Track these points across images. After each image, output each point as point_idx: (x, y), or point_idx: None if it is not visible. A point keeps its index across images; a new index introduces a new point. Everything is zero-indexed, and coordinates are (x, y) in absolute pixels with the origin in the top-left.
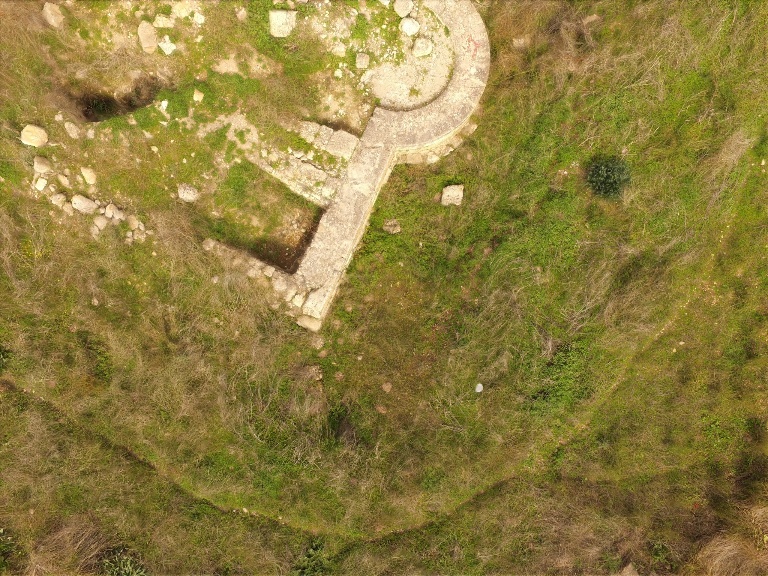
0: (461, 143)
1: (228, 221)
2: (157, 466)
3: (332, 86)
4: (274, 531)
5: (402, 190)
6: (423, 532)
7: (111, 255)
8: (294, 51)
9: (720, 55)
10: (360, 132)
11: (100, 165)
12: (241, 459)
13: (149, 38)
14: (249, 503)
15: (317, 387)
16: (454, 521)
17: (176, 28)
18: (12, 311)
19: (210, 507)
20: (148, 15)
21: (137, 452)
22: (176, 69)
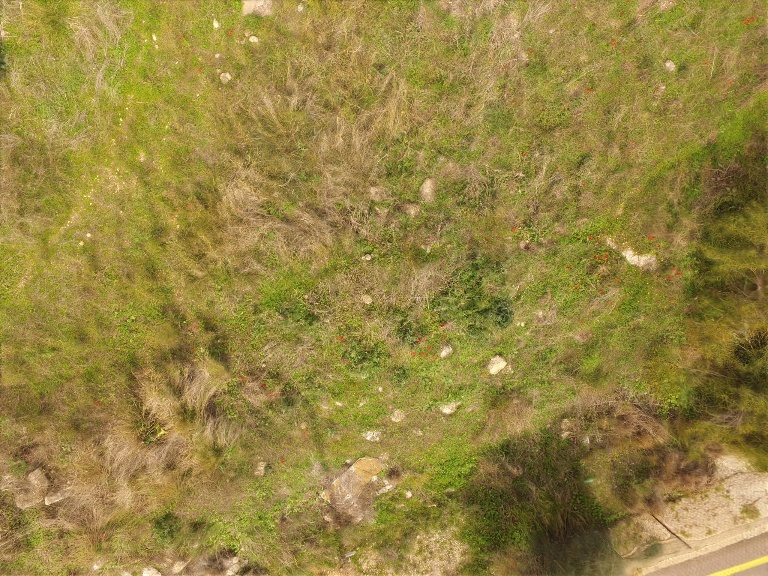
0: None
1: None
2: None
3: None
4: None
5: None
6: None
7: None
8: None
9: None
10: None
11: None
12: None
13: None
14: None
15: None
16: None
17: None
18: None
19: None
20: None
21: None
22: None
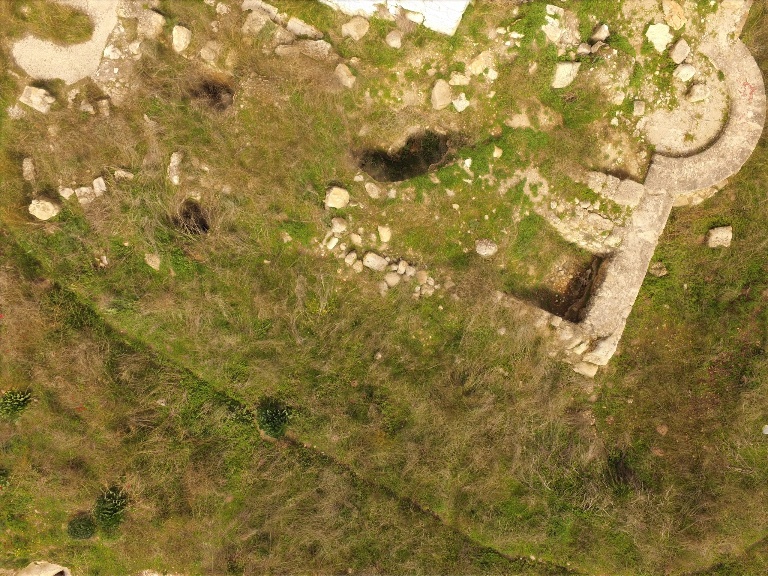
0: (726, 184)
1: (510, 272)
2: (441, 516)
3: (610, 134)
4: None
5: (669, 233)
6: (713, 574)
7: (407, 312)
8: (573, 101)
9: None
10: (640, 179)
11: (399, 224)
12: (530, 508)
13: (445, 96)
14: (538, 551)
15: (592, 432)
16: (745, 562)
17: (471, 85)
18: (293, 368)
19: (497, 556)
20: (441, 73)
21: (421, 503)
22: (465, 125)
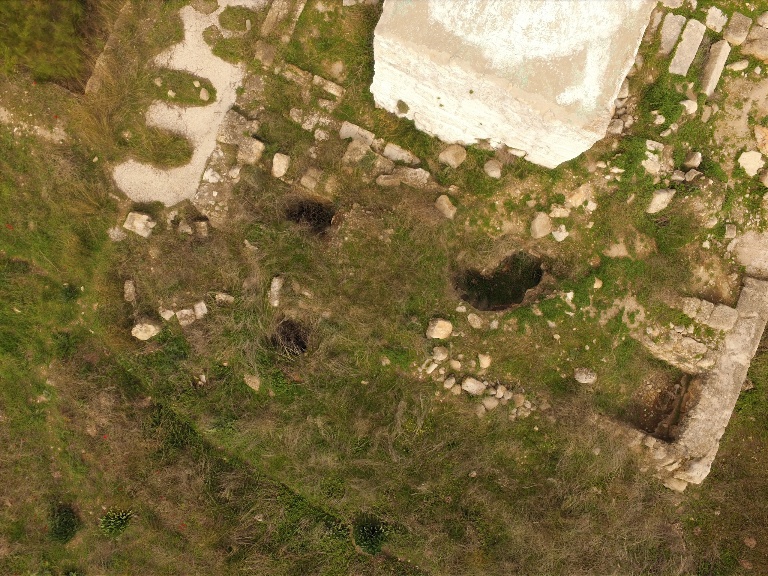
0: None
1: (604, 392)
2: None
3: (702, 257)
4: None
5: None
6: None
7: (506, 437)
8: (666, 226)
9: None
10: (732, 302)
11: (499, 352)
12: None
13: (545, 228)
14: None
15: (681, 544)
16: None
17: (571, 217)
18: (389, 485)
19: None
20: (541, 204)
21: None
22: (563, 253)
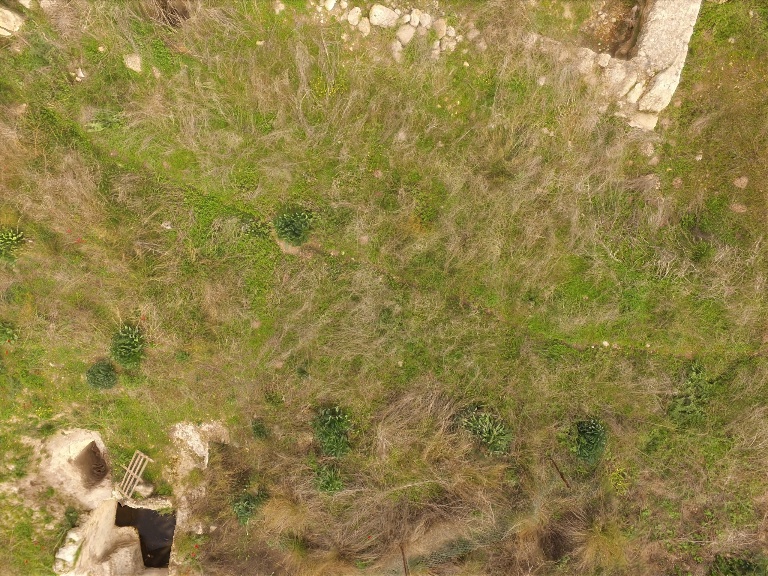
0: None
1: (543, 12)
2: (495, 312)
3: None
4: (646, 360)
5: None
6: None
7: None
8: None
9: None
10: None
11: None
12: (597, 285)
13: None
14: (612, 334)
15: (658, 197)
16: None
17: None
18: (307, 165)
19: (565, 347)
20: None
21: (471, 300)
22: None
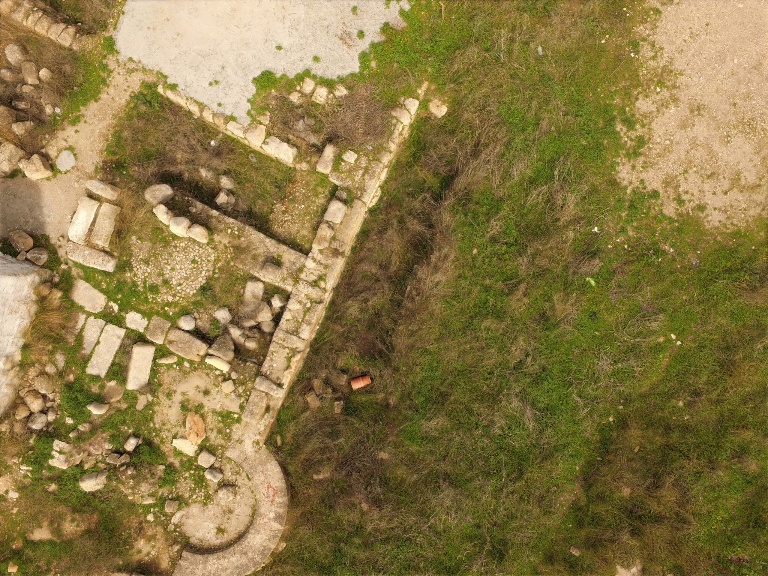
0: (271, 560)
1: None
2: None
3: (144, 530)
4: None
5: None
6: None
7: None
8: (108, 501)
9: (493, 507)
10: (170, 572)
11: None
12: None
13: None
14: None
15: None
16: None
17: None
18: None
19: None
20: None
21: None
22: None
